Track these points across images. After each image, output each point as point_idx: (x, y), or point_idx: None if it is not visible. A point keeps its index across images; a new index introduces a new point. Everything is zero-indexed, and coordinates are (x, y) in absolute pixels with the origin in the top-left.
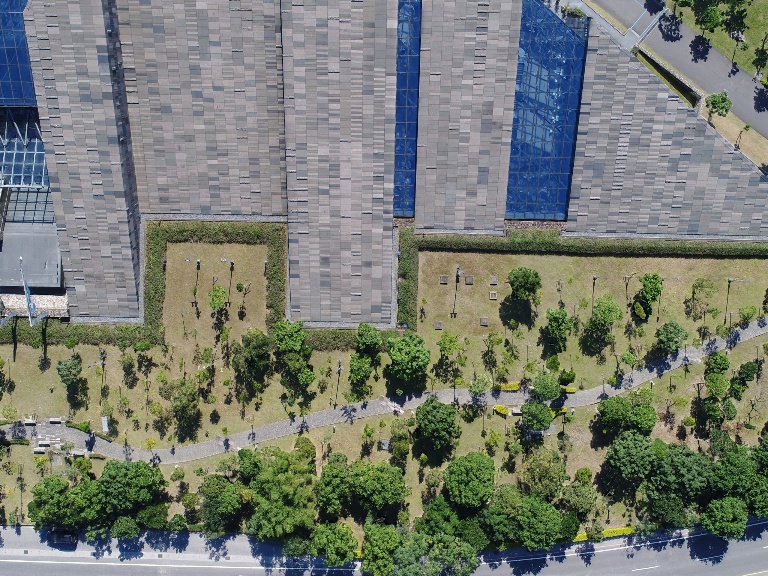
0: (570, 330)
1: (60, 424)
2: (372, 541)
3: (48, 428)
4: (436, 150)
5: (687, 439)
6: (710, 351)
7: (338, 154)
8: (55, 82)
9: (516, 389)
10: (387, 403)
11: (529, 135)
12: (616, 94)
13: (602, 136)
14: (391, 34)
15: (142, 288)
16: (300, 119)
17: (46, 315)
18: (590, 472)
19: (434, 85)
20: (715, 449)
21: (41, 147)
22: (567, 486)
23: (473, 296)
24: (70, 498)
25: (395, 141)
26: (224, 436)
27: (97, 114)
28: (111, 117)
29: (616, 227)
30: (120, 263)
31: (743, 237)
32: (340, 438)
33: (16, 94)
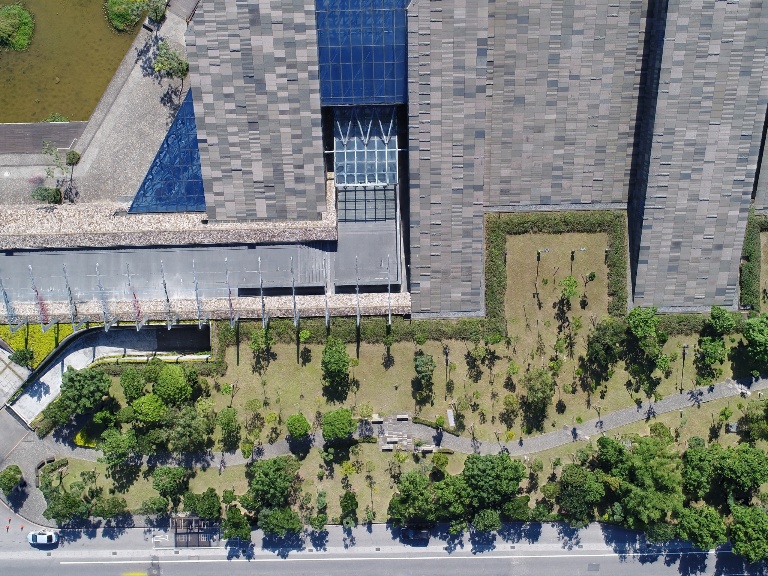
0: None
1: (407, 421)
2: (746, 523)
3: (395, 425)
4: None
5: None
6: None
7: (705, 137)
8: (430, 77)
9: None
10: (734, 385)
11: None
12: None
13: None
14: None
15: (482, 281)
16: (672, 104)
17: None
18: None
19: None
20: None
21: (381, 145)
22: None
23: None
24: (438, 493)
25: None
26: (571, 425)
27: (468, 108)
28: (481, 110)
29: None
30: (469, 257)
31: None
32: (687, 422)
33: (367, 92)
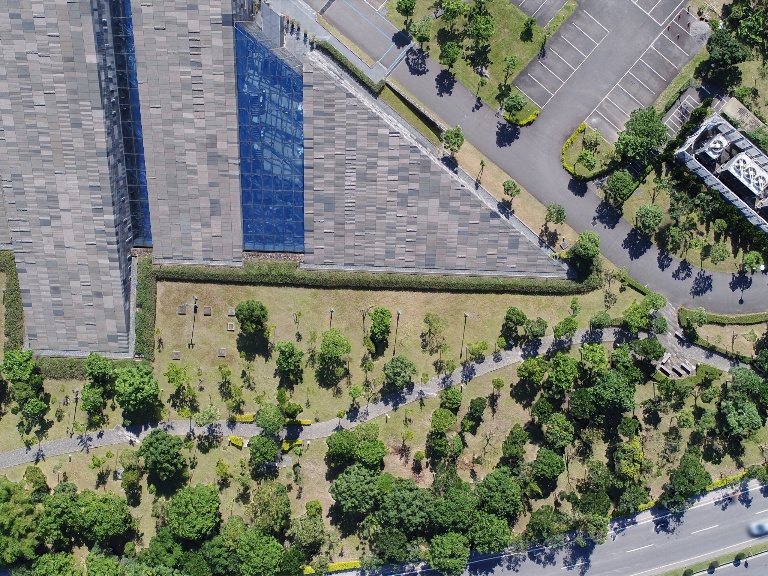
0: (307, 362)
1: None
2: (89, 572)
3: None
4: (165, 182)
5: (422, 473)
6: (445, 385)
7: (54, 186)
8: None
9: (251, 420)
10: (123, 433)
11: (277, 166)
12: (337, 129)
13: (328, 170)
14: (91, 69)
15: None
16: (12, 151)
17: None
18: (317, 505)
19: (155, 118)
20: (438, 484)
21: None
22: (295, 519)
23: (211, 327)
24: None
25: (126, 172)
26: None
27: None
28: None
29: (354, 260)
30: None
31: (481, 272)
32: (76, 467)
33: None
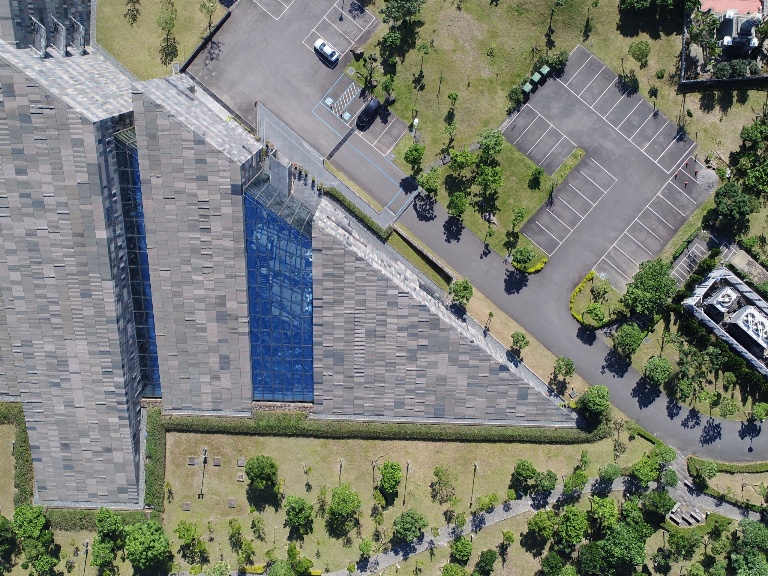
0: (317, 512)
1: None
2: None
3: None
4: (175, 338)
5: None
6: (455, 535)
7: (64, 351)
8: None
9: (261, 572)
10: None
11: None
12: (346, 290)
13: (338, 328)
14: (101, 243)
15: None
16: (22, 319)
17: None
18: None
19: (165, 280)
20: None
21: None
22: None
23: (221, 477)
24: None
25: (135, 328)
26: None
27: None
28: None
29: (363, 410)
30: None
31: (490, 421)
32: None
33: None
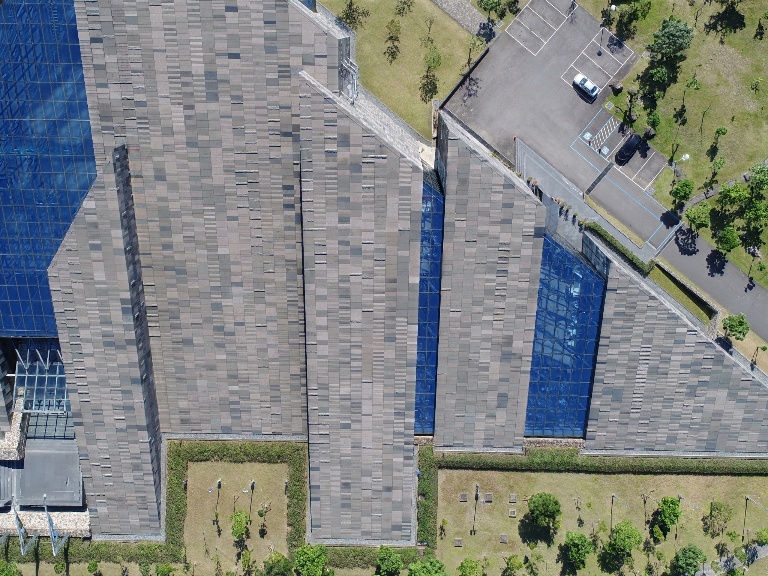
0: None
1: None
2: None
3: None
4: (456, 378)
5: None
6: (728, 568)
7: (360, 393)
8: (79, 330)
9: None
10: None
11: (547, 347)
12: (635, 329)
13: (621, 365)
14: (413, 289)
15: (163, 506)
16: (322, 362)
17: (68, 535)
18: None
19: (454, 321)
20: None
21: (63, 371)
22: None
23: (492, 513)
24: None
25: None
26: None
27: (120, 358)
28: (134, 361)
29: (634, 445)
30: (142, 488)
31: (760, 454)
32: None
33: (38, 326)
